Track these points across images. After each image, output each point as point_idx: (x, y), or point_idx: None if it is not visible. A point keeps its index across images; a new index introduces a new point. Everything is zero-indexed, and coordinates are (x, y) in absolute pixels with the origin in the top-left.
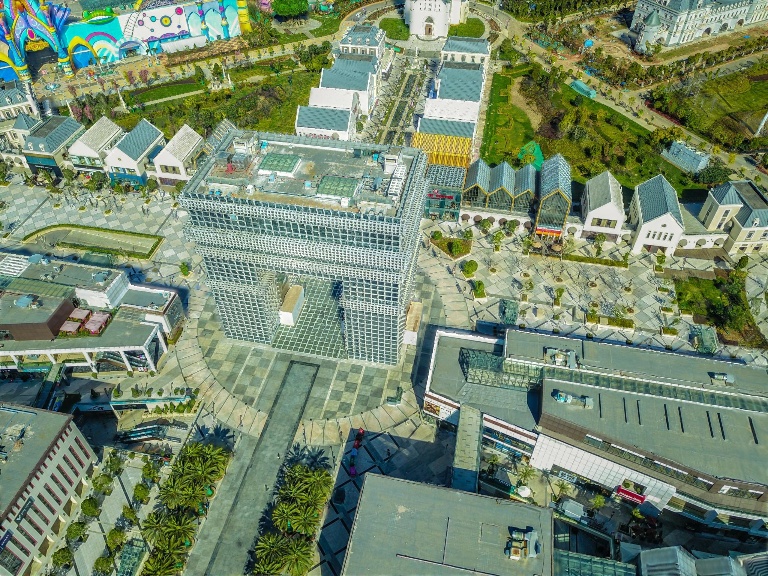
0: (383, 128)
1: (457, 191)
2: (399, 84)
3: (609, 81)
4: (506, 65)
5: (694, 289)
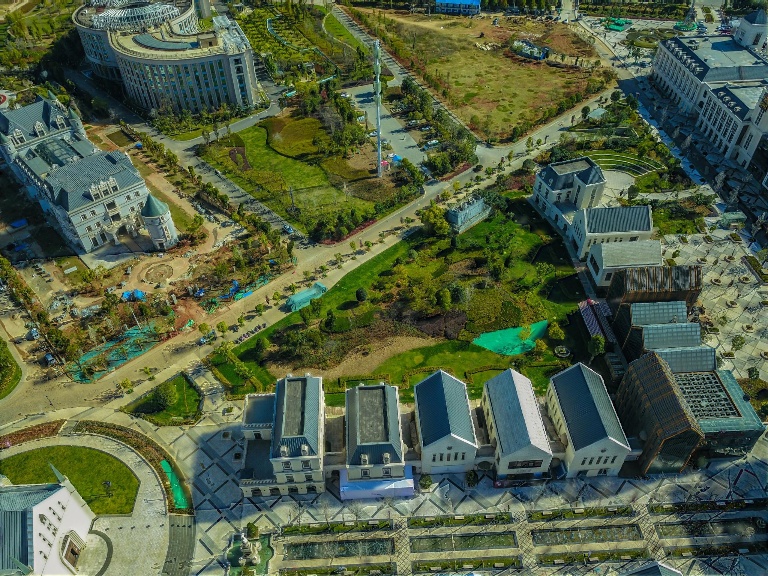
0: (531, 558)
1: (728, 375)
2: (344, 571)
3: (270, 274)
4: (227, 395)
5: (664, 225)
